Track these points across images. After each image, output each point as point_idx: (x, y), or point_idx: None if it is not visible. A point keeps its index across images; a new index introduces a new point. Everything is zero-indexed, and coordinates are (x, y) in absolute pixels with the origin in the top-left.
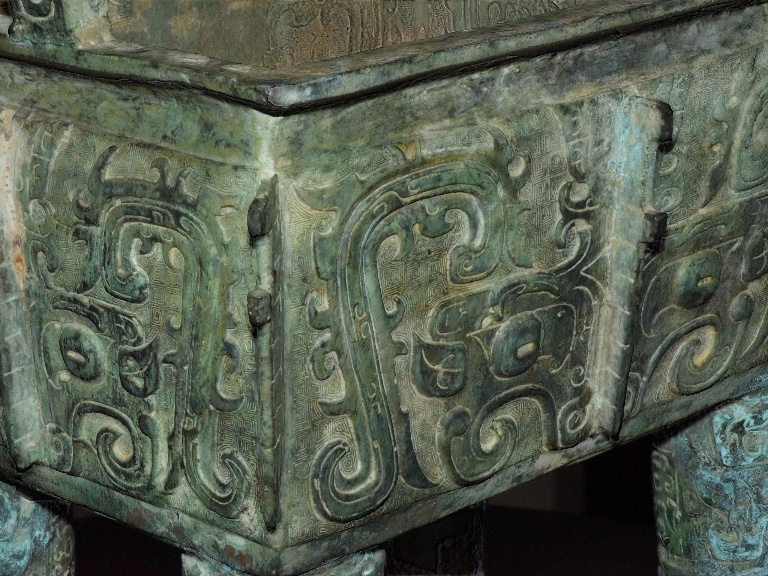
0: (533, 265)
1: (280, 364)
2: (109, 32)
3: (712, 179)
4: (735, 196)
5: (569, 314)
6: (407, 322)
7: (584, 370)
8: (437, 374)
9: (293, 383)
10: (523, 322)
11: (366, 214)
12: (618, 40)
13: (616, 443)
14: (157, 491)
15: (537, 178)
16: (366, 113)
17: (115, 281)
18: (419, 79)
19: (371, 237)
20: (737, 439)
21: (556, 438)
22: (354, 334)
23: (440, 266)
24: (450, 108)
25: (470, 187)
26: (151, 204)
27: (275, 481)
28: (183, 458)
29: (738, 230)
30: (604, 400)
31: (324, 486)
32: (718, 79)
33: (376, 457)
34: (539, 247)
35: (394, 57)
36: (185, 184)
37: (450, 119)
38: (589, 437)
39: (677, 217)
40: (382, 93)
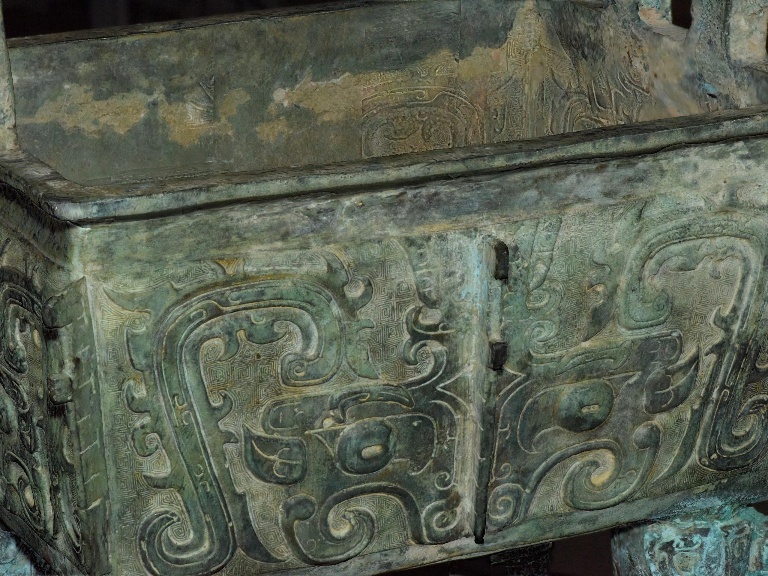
0: (380, 377)
1: (97, 438)
2: (13, 142)
3: (594, 316)
4: (627, 333)
5: (427, 424)
6: (236, 415)
7: (450, 476)
8: (273, 463)
9: (116, 456)
10: (369, 426)
11: (182, 318)
12: (480, 184)
13: (507, 546)
14: (50, 535)
15: (381, 300)
16: (187, 231)
17: (8, 352)
18: (243, 205)
19: (191, 338)
20: (667, 557)
21: (421, 534)
22: (175, 420)
23: (271, 369)
24: (284, 232)
25: (299, 303)
26: (21, 291)
27: (90, 538)
28: (56, 509)
29: (633, 365)
30: (472, 505)
31: (150, 548)
32: (596, 226)
33: (209, 529)
34: (386, 362)
35: (193, 186)
36: (37, 277)
37: (282, 242)
38: (470, 537)
39: (554, 347)
40: (204, 215)
